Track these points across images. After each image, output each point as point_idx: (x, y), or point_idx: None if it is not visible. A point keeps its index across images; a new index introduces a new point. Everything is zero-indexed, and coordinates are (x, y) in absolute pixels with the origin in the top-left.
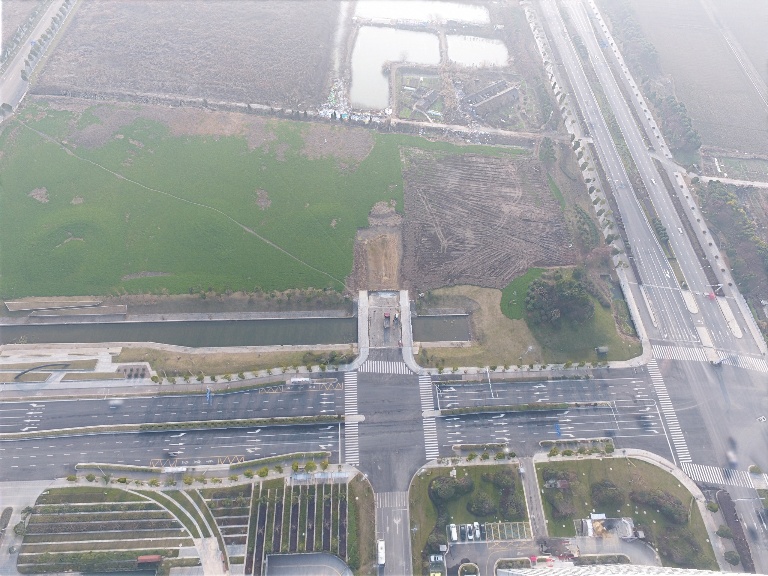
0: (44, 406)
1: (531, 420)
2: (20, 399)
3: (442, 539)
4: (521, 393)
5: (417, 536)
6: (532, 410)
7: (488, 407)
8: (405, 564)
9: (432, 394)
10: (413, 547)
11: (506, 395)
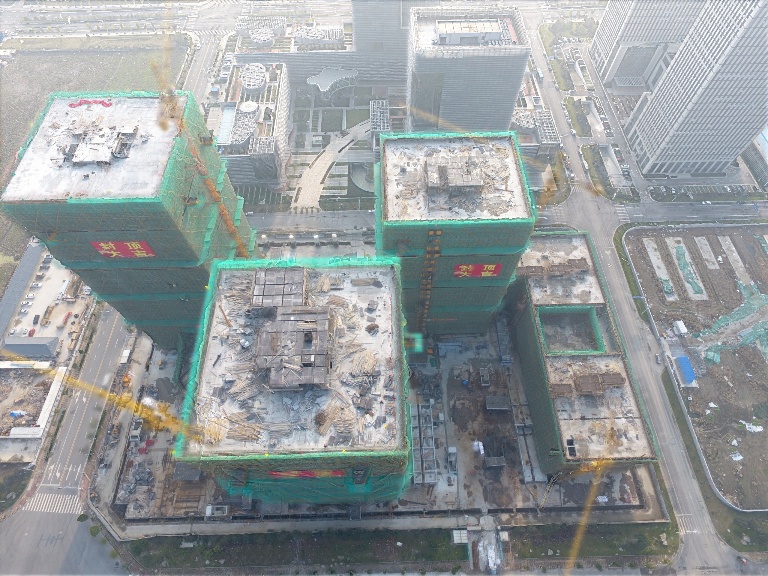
0: (341, 6)
1: (601, 9)
2: (328, 4)
3: (560, 37)
4: (594, 1)
5: (545, 41)
6: (601, 5)
7: (577, 2)
8: (541, 49)
9: (544, 1)
10: (544, 44)
11: (586, 1)
